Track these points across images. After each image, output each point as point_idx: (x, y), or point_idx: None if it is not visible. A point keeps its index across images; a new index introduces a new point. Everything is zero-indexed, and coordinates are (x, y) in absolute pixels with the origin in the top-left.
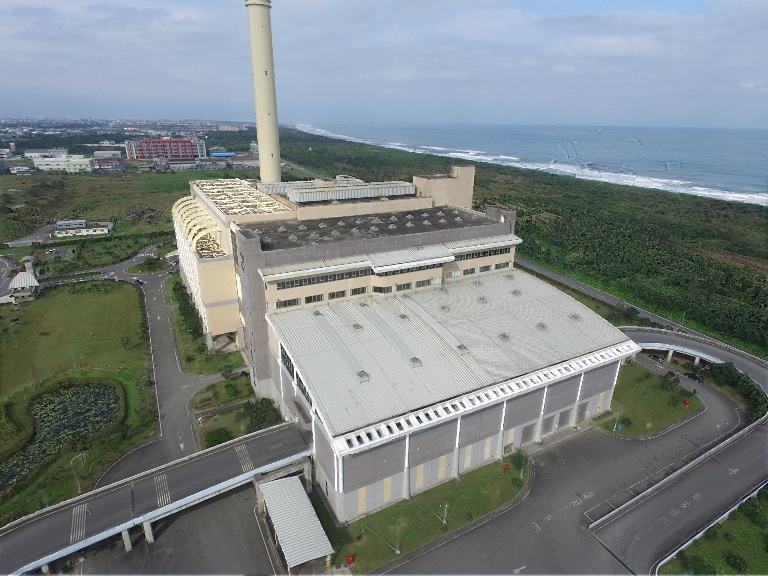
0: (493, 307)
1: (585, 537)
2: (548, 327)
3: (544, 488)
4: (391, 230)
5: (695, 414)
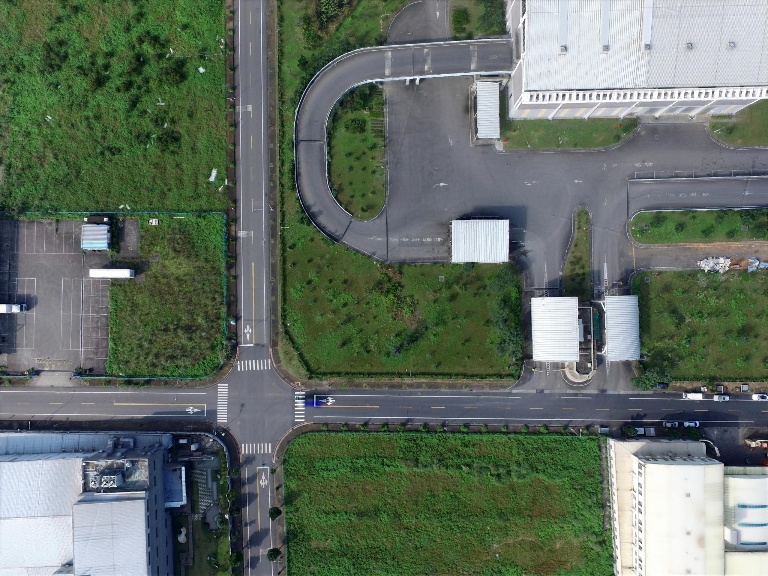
0: (716, 2)
1: (623, 183)
2: (737, 47)
3: (629, 148)
4: None
5: None
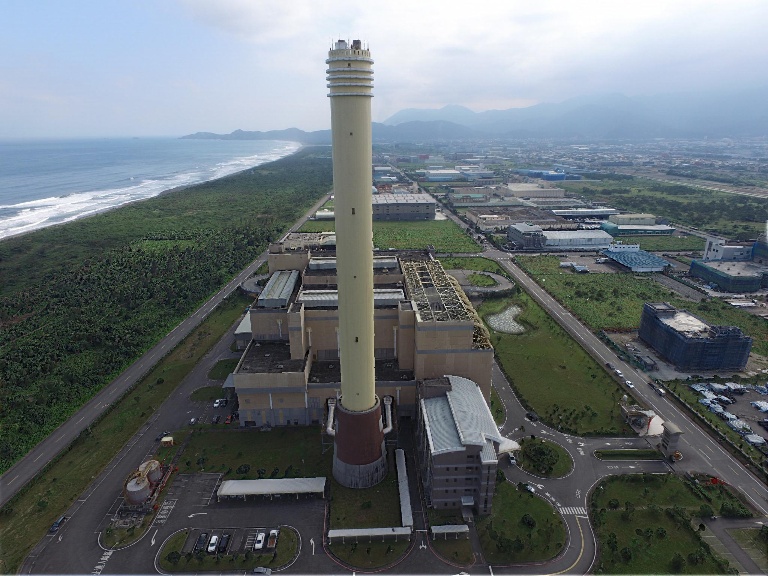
0: None
1: None
2: None
3: None
4: None
5: None
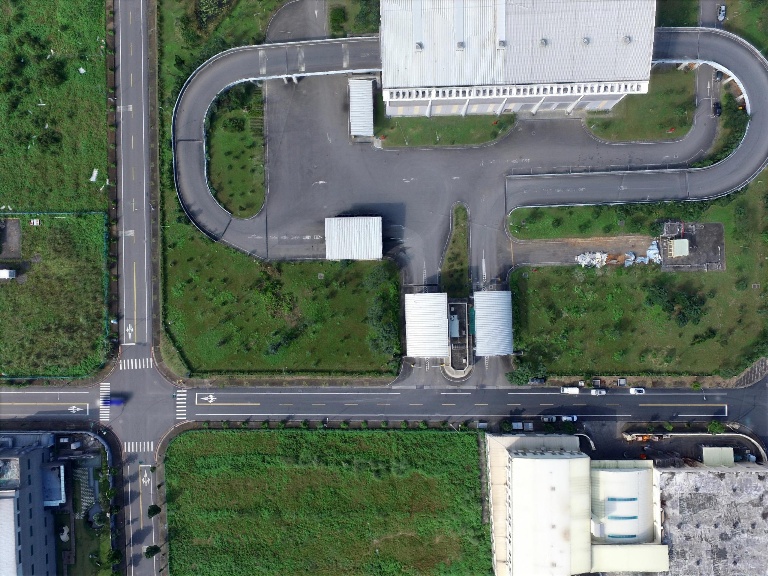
0: None
1: (501, 179)
2: (592, 42)
3: (506, 145)
4: None
5: (665, 141)
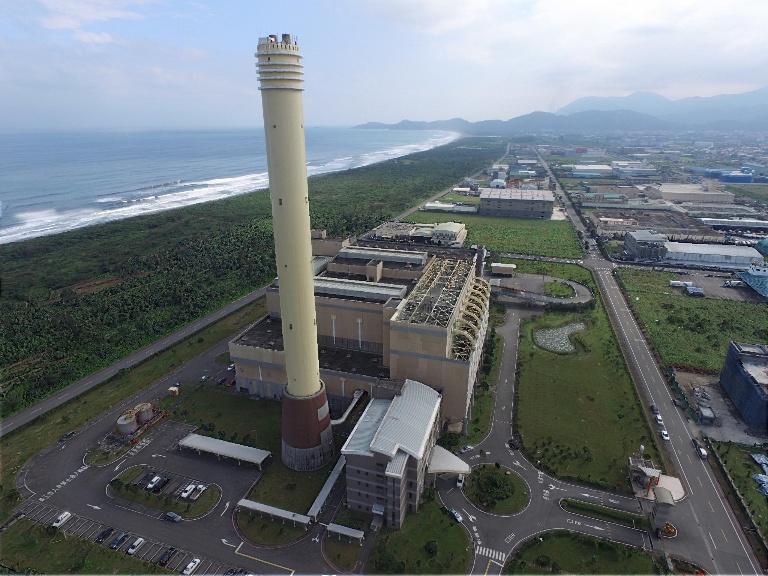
0: None
1: None
2: None
3: None
4: (409, 249)
5: None
